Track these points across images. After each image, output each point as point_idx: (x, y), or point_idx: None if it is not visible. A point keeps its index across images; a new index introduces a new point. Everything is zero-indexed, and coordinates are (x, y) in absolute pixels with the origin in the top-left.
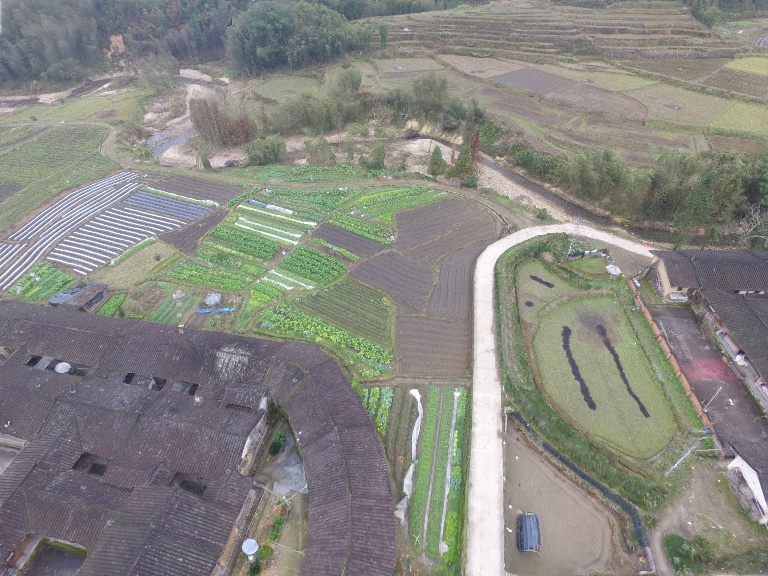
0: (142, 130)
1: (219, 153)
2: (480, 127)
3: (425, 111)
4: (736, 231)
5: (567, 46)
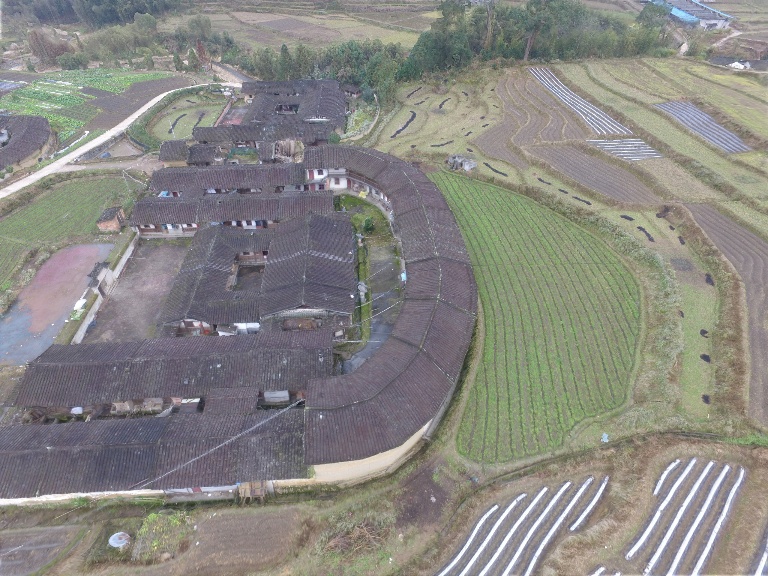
0: None
1: (49, 68)
2: (231, 50)
3: None
4: (308, 78)
5: (322, 4)
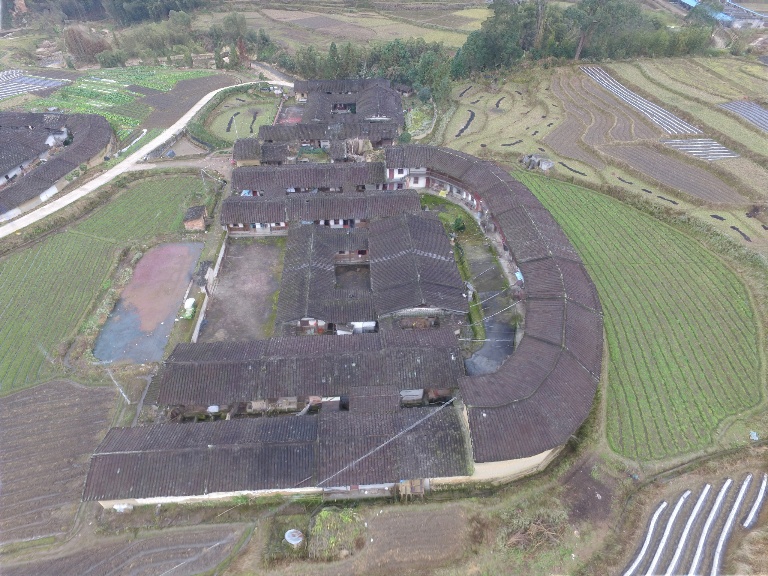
0: (32, 55)
1: (86, 66)
2: (267, 48)
3: (234, 40)
4: (356, 77)
5: (352, 2)
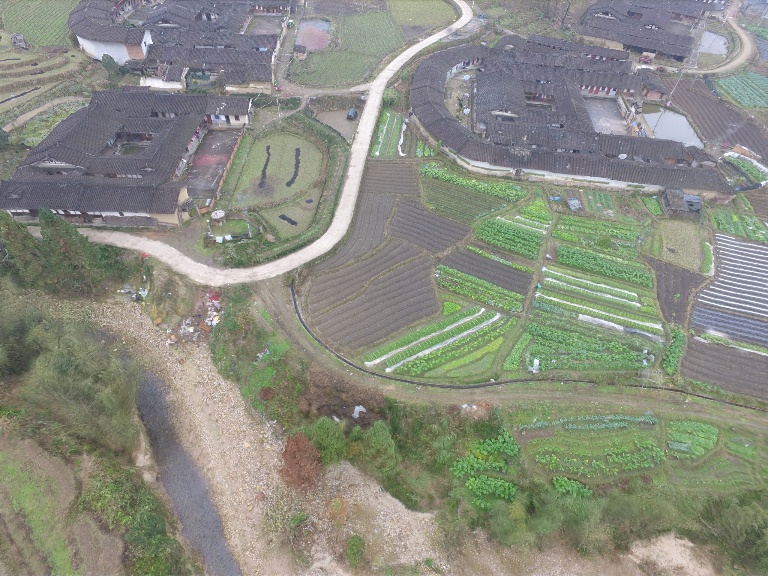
0: None
1: None
2: None
3: None
4: None
5: None
